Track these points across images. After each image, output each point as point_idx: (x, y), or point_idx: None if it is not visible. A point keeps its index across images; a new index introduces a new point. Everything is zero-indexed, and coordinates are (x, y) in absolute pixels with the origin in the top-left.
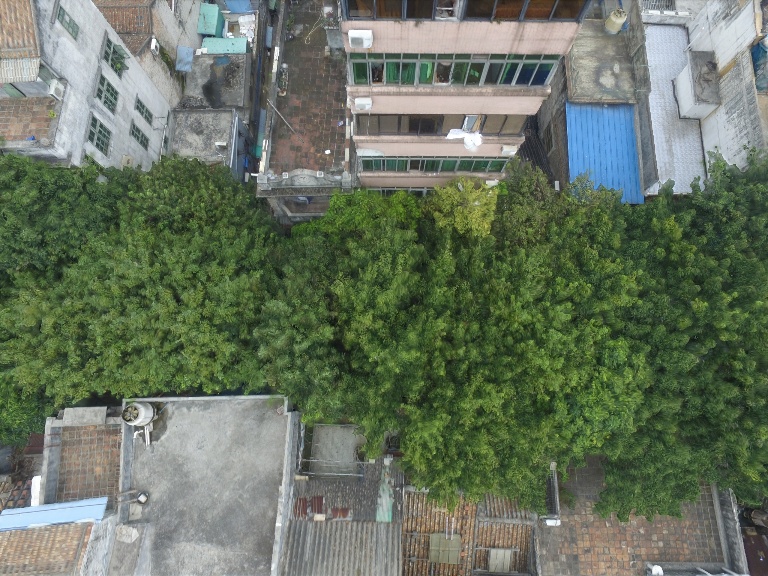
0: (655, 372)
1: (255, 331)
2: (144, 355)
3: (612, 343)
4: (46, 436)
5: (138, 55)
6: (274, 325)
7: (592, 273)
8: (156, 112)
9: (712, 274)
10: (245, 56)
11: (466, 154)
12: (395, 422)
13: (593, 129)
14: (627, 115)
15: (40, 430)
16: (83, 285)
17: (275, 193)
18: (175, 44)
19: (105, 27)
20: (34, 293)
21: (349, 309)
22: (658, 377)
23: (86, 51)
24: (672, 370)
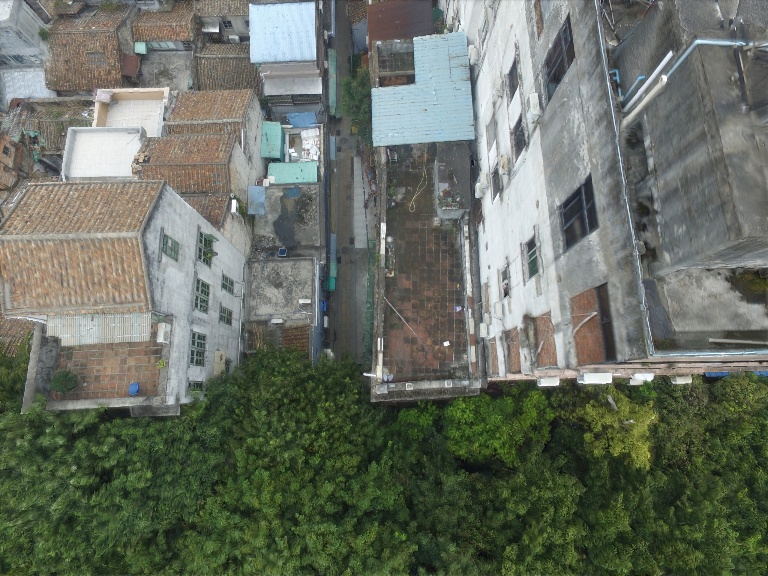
0: None
1: None
2: None
3: None
4: None
5: (221, 226)
6: None
7: None
8: (236, 275)
9: None
10: (317, 186)
11: None
12: None
13: None
14: None
15: None
16: (211, 571)
17: (392, 396)
18: (246, 185)
19: (197, 222)
20: None
21: None
22: None
23: (185, 265)
24: None
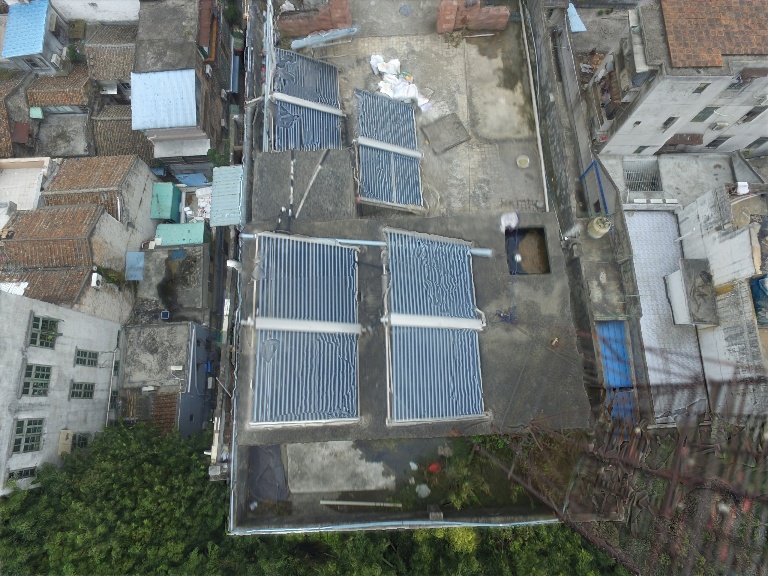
0: None
1: None
2: None
3: None
4: None
5: (76, 302)
6: None
7: None
8: (102, 345)
9: None
10: (202, 248)
11: None
12: None
13: None
14: (617, 333)
15: None
16: None
17: None
18: (123, 252)
19: (30, 307)
20: None
21: None
22: None
23: (5, 356)
24: None
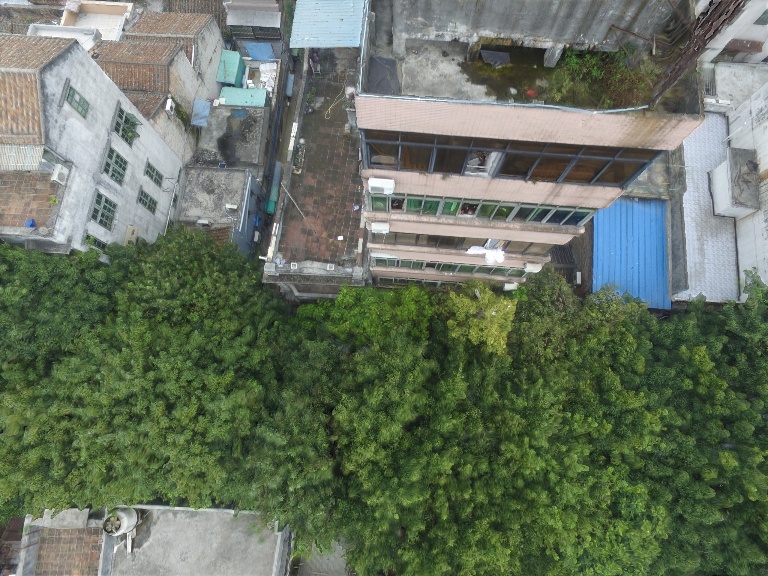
0: (674, 519)
1: (248, 459)
2: (130, 470)
3: (630, 490)
4: (24, 535)
5: (152, 118)
6: (269, 455)
7: (613, 405)
8: (167, 172)
9: (743, 415)
10: (263, 110)
11: (486, 264)
12: (391, 563)
13: (621, 224)
14: (658, 211)
15: (21, 516)
16: (72, 387)
17: (282, 279)
18: (192, 97)
19: (118, 97)
20: (20, 396)
21: (350, 432)
22: (677, 526)
23: (95, 127)
24: (693, 520)
